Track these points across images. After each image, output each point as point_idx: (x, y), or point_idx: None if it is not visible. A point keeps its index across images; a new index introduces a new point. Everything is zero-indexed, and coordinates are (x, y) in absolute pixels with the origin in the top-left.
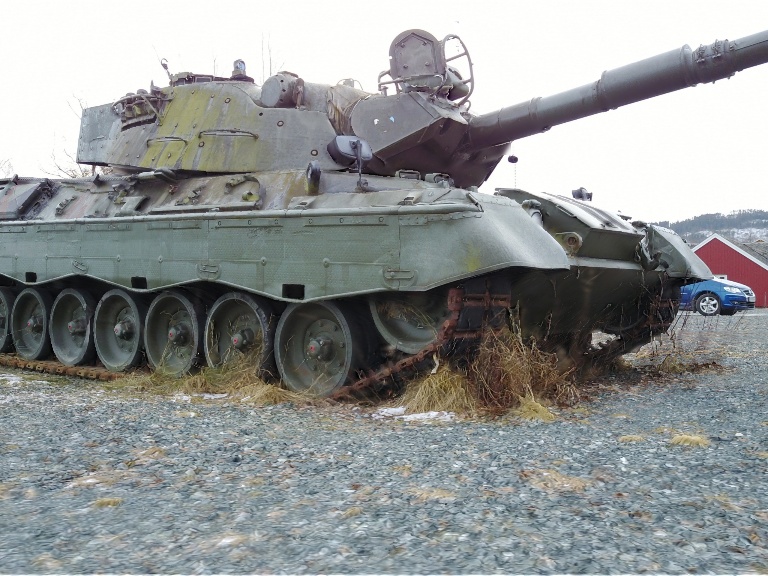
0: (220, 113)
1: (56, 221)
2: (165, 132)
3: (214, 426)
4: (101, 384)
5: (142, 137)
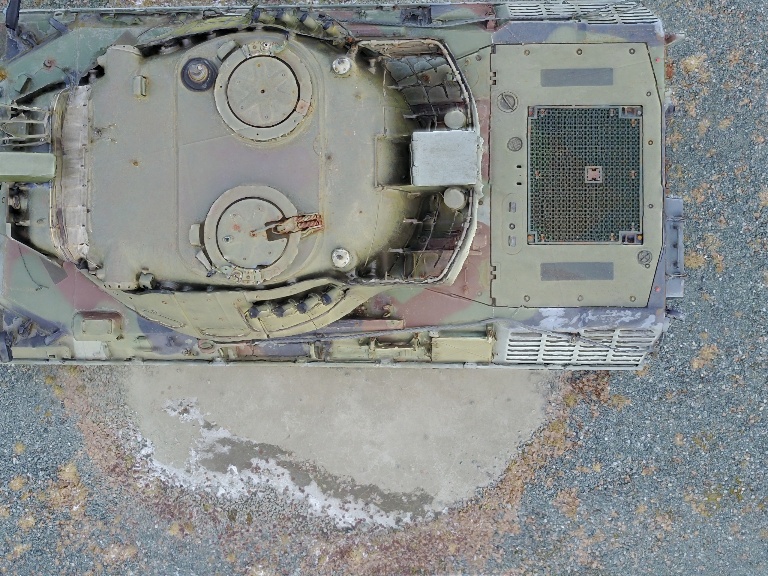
0: None
1: (344, 4)
2: (238, 23)
3: None
4: None
5: None
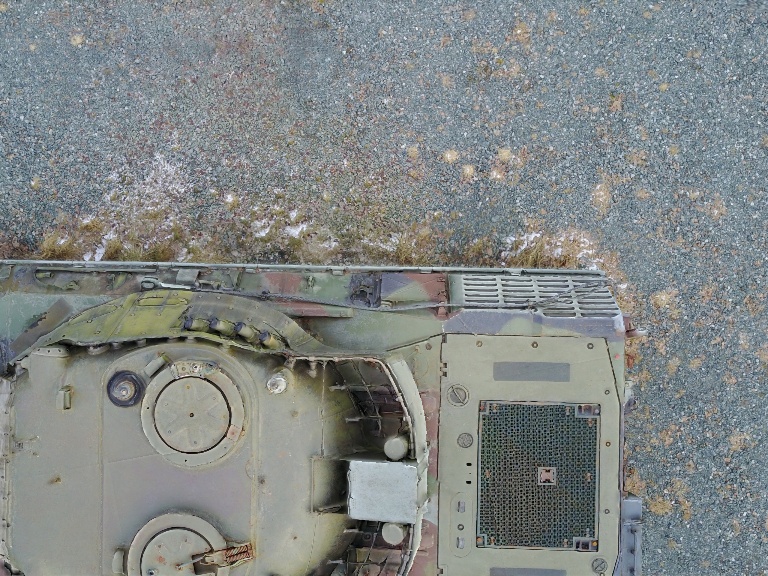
0: (104, 324)
1: None
2: (174, 311)
3: (5, 171)
4: (226, 257)
5: (207, 308)
